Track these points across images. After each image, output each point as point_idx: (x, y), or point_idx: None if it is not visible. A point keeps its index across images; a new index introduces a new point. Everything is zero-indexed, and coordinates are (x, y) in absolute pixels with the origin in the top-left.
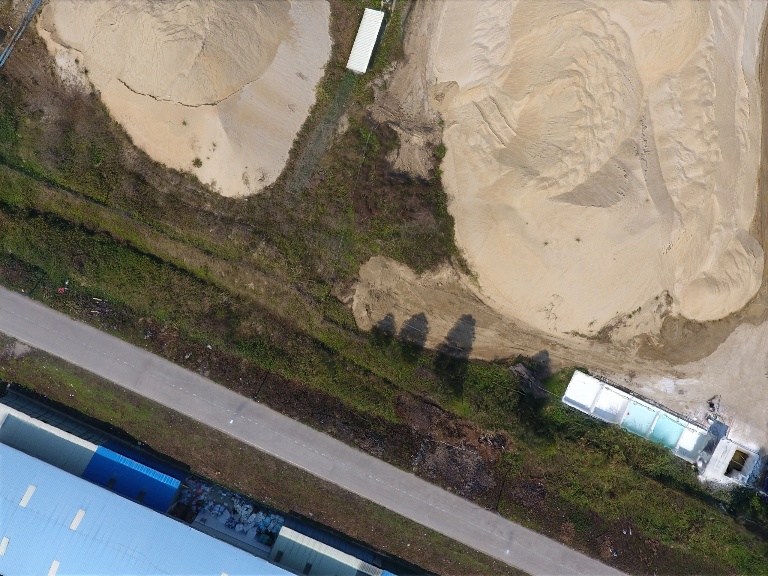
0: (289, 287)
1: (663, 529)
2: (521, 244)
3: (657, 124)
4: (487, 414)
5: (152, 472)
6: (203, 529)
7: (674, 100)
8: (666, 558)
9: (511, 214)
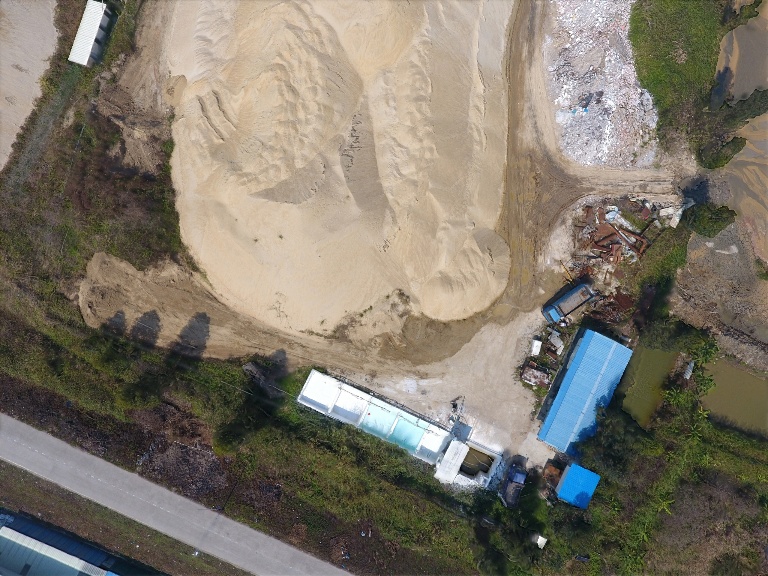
0: (10, 283)
1: (405, 531)
2: (233, 241)
3: (376, 120)
4: (214, 413)
5: None
6: None
7: (389, 95)
8: (405, 560)
9: (220, 210)
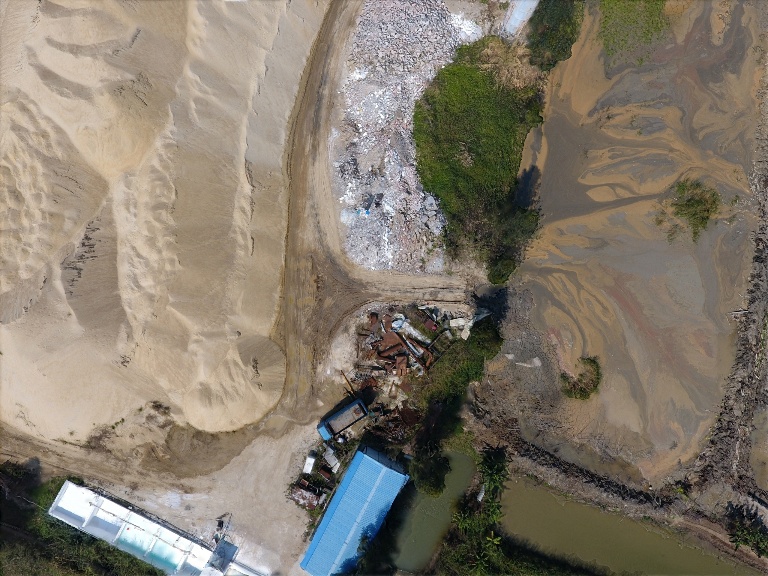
0: None
1: None
2: None
3: (119, 225)
4: None
5: None
6: None
7: (130, 201)
8: None
9: None
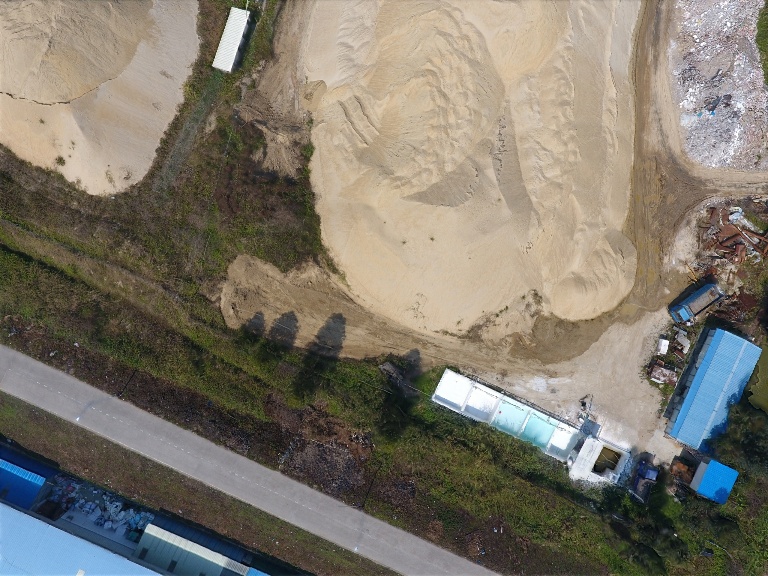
0: (155, 285)
1: (535, 527)
2: (380, 243)
3: (518, 124)
4: (354, 412)
5: (17, 469)
6: (67, 526)
7: (533, 100)
8: (536, 556)
9: (369, 213)
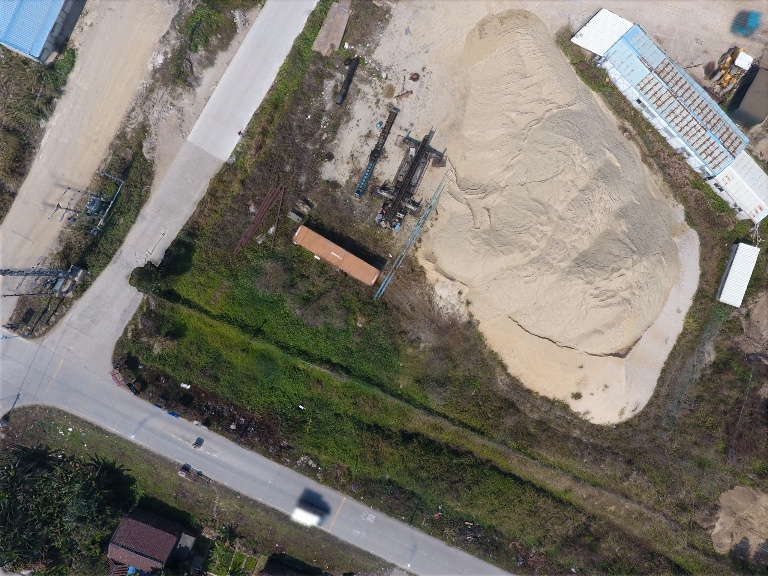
0: (656, 515)
1: None
2: None
3: None
4: None
5: None
6: None
7: None
8: None
9: None
